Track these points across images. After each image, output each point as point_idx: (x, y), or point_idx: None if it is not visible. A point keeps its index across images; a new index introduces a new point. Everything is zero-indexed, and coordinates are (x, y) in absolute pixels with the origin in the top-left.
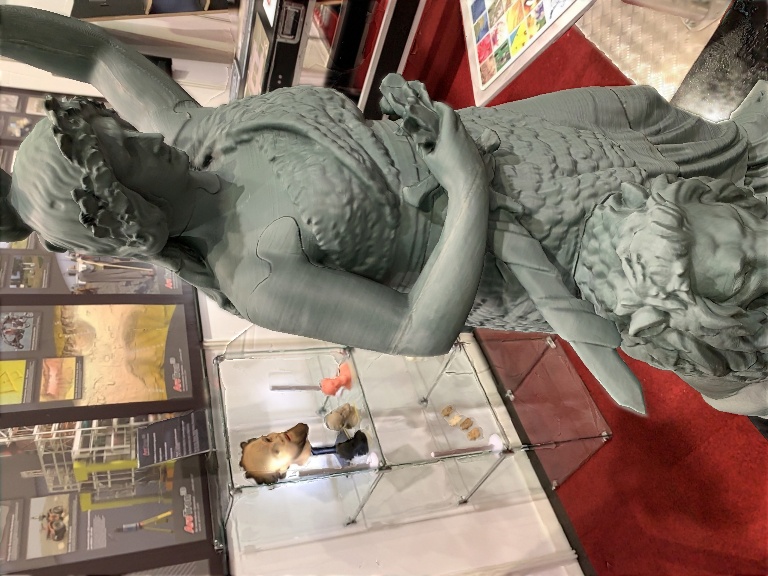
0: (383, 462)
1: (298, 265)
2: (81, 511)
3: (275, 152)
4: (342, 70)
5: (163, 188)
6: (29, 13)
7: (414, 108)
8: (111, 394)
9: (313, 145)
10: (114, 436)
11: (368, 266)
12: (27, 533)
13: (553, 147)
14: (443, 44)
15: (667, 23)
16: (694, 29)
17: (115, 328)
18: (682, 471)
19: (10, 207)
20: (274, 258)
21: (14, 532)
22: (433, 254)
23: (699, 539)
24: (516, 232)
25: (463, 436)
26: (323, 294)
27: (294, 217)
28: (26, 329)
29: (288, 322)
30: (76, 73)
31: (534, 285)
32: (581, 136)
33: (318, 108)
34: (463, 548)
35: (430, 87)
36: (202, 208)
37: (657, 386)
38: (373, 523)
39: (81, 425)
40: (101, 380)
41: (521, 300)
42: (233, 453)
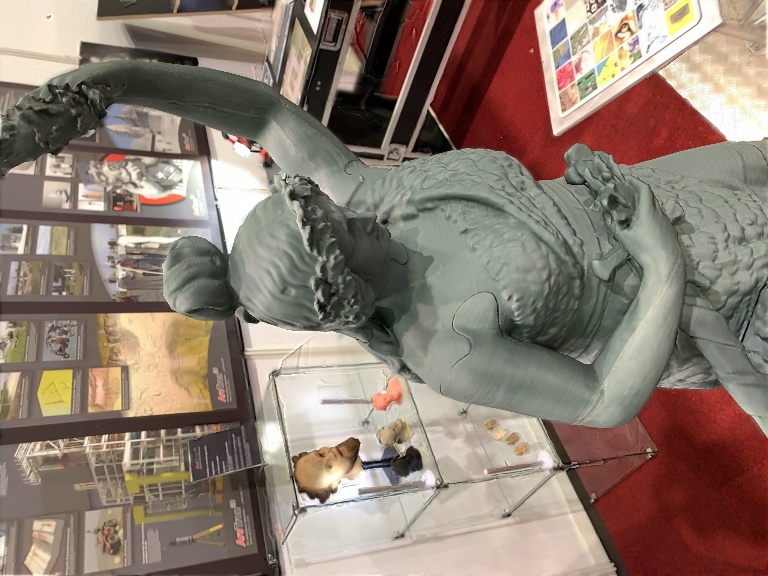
0: (440, 480)
1: (496, 341)
2: (135, 524)
3: (466, 224)
4: (378, 76)
5: (372, 266)
6: (213, 76)
7: (616, 186)
8: (158, 405)
9: (507, 218)
10: (163, 448)
11: (550, 336)
12: (83, 547)
13: (720, 213)
14: (477, 51)
15: (728, 45)
16: (758, 53)
17: (158, 337)
18: (733, 491)
19: (229, 287)
20: (472, 333)
21: (70, 546)
22: (624, 329)
23: (749, 559)
24: (703, 306)
25: (500, 447)
26: (521, 370)
27: (493, 293)
28: (71, 338)
29: (483, 396)
30: (247, 132)
31: (721, 360)
32: (740, 199)
33: (503, 177)
34: (506, 561)
35: (462, 93)
36: (394, 279)
37: (707, 406)
38: (418, 536)
39: (130, 436)
40: (147, 390)
41: (687, 366)
42: (279, 465)
